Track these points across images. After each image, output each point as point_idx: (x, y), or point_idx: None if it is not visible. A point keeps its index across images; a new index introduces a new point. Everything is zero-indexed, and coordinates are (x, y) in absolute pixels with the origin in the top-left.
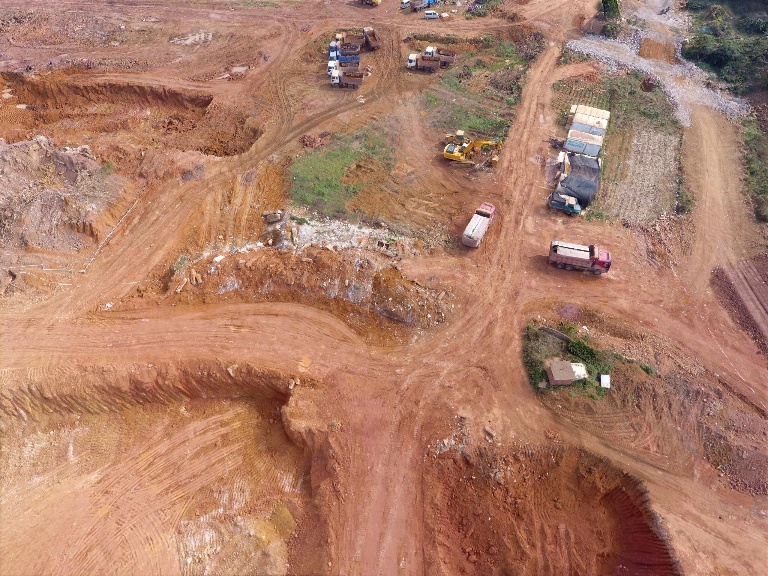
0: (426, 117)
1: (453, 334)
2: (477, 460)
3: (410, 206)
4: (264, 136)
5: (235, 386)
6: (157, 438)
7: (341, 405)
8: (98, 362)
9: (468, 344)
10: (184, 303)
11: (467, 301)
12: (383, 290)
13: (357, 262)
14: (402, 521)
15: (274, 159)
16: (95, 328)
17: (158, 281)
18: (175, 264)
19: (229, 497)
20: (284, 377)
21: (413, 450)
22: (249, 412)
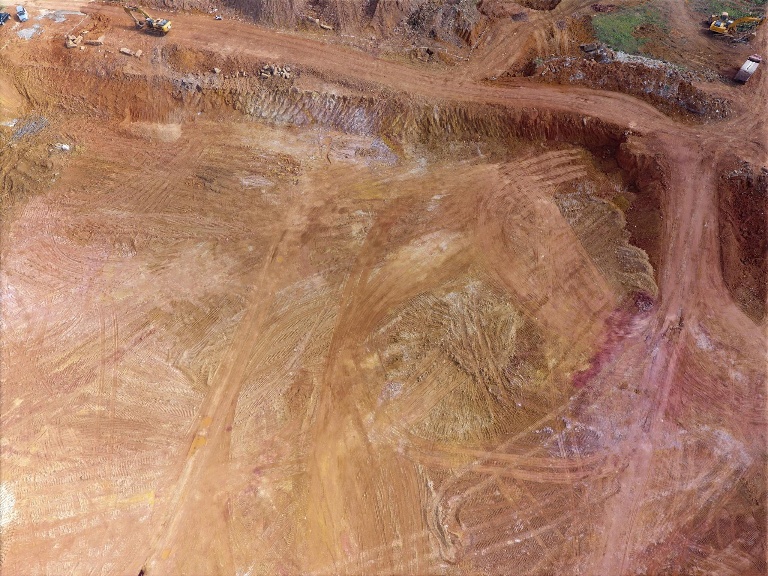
0: (690, 4)
1: (733, 124)
2: (756, 183)
3: (686, 57)
4: (564, 1)
5: (582, 133)
6: (529, 155)
7: (662, 146)
8: (500, 103)
9: (745, 130)
10: (546, 82)
11: (740, 110)
12: (687, 91)
13: (668, 72)
14: (705, 206)
15: (576, 16)
16: (490, 88)
17: (518, 72)
18: (536, 60)
19: (583, 188)
20: (621, 128)
21: (711, 174)
22: (586, 152)
